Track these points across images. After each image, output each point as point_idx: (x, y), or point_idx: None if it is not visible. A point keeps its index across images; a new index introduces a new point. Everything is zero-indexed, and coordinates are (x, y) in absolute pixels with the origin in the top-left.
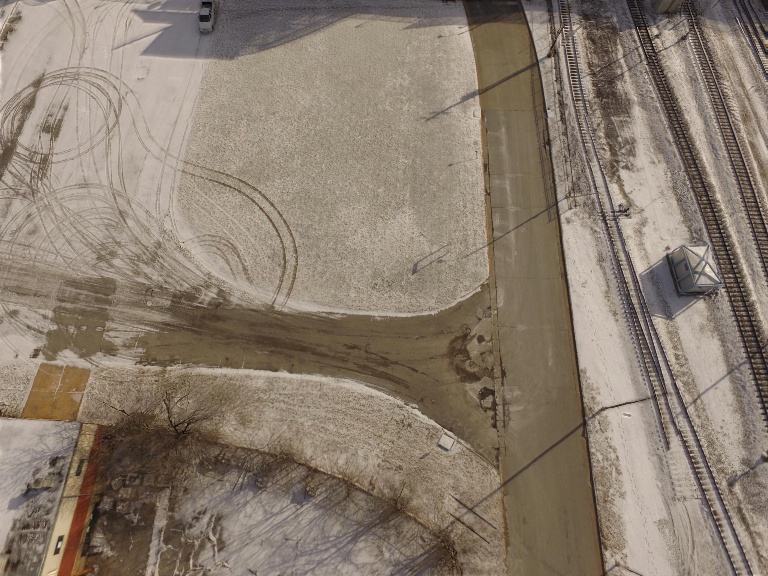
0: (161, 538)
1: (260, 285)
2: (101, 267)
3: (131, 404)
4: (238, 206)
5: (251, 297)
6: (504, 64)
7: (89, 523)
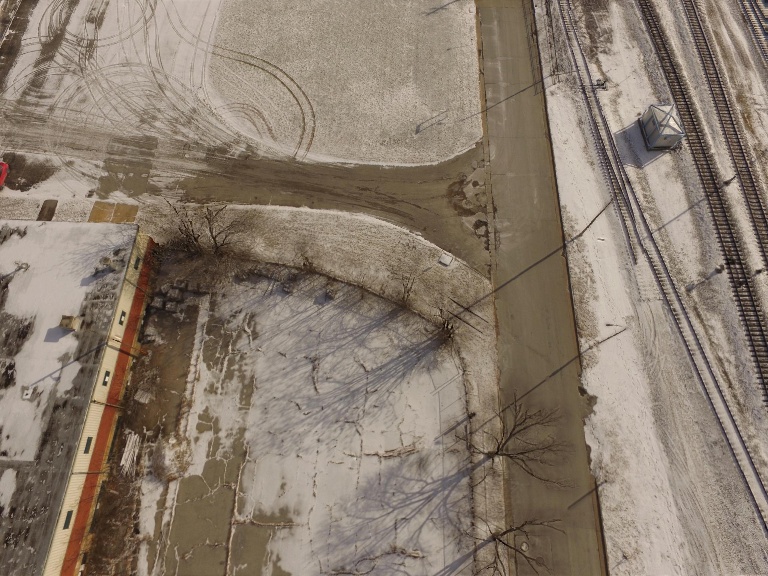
0: (204, 331)
1: (283, 142)
2: (144, 128)
3: (175, 231)
4: (262, 81)
5: (275, 151)
6: None
7: (143, 317)
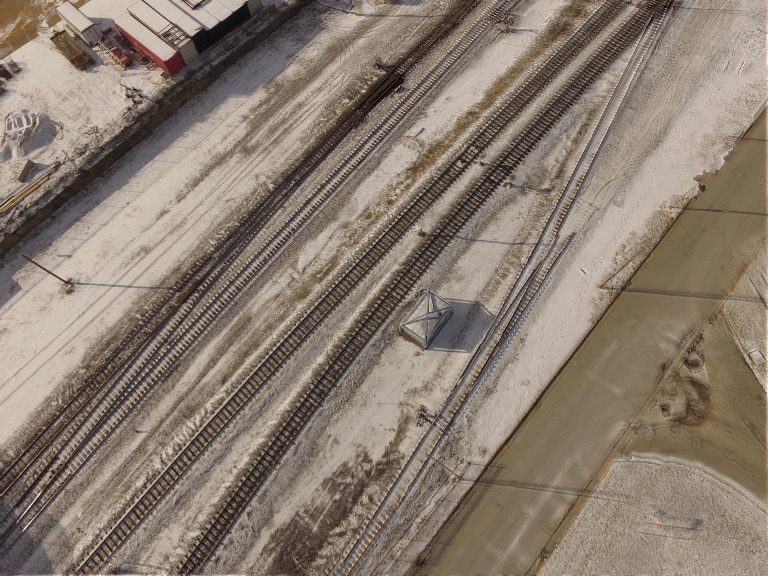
0: None
1: None
2: None
3: None
4: None
5: None
6: None
7: None
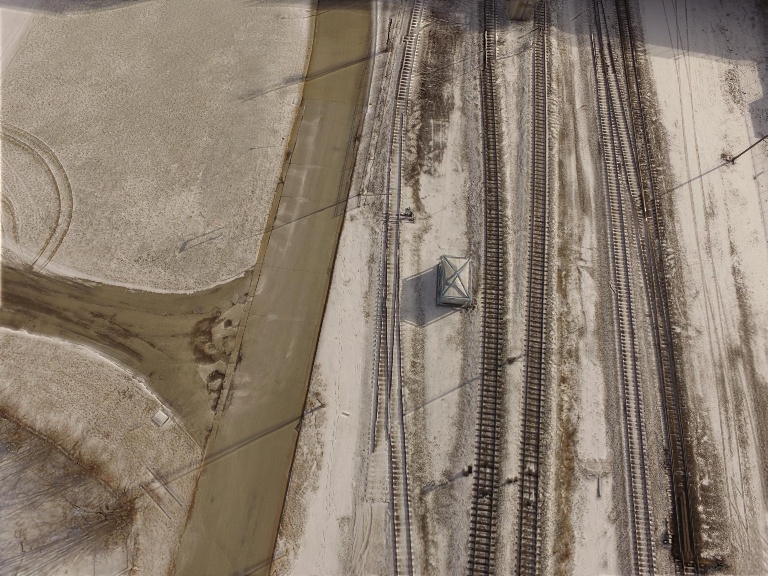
0: None
1: (25, 245)
2: None
3: None
4: (27, 164)
5: (13, 255)
6: (340, 53)
7: None
